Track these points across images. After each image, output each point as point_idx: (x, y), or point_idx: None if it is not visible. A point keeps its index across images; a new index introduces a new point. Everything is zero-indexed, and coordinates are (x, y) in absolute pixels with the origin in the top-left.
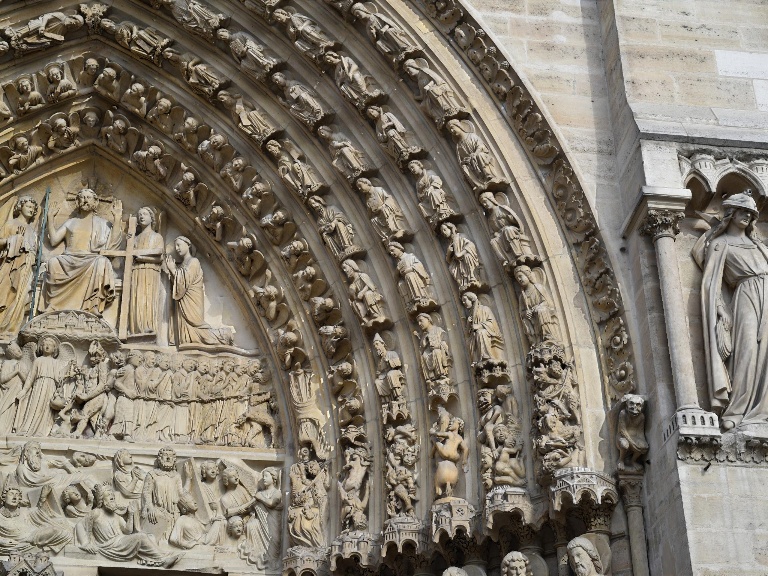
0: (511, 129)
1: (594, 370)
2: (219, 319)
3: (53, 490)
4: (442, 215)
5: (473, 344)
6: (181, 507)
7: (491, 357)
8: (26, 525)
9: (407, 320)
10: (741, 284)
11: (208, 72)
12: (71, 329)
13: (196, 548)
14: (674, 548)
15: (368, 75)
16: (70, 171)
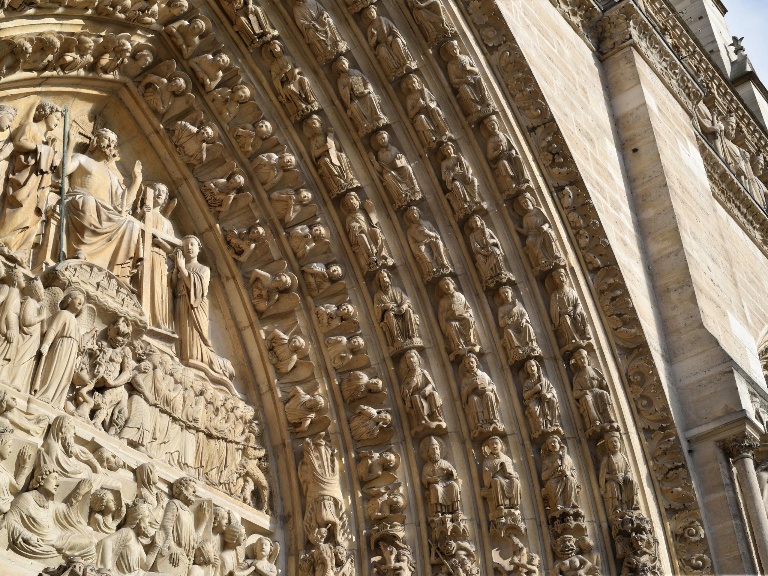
0: (593, 300)
1: (665, 551)
2: None
3: None
4: (535, 351)
5: (562, 488)
6: (198, 554)
7: None
8: (52, 523)
9: (464, 435)
10: None
11: None
12: (103, 292)
13: None
14: None
15: None
16: (87, 98)
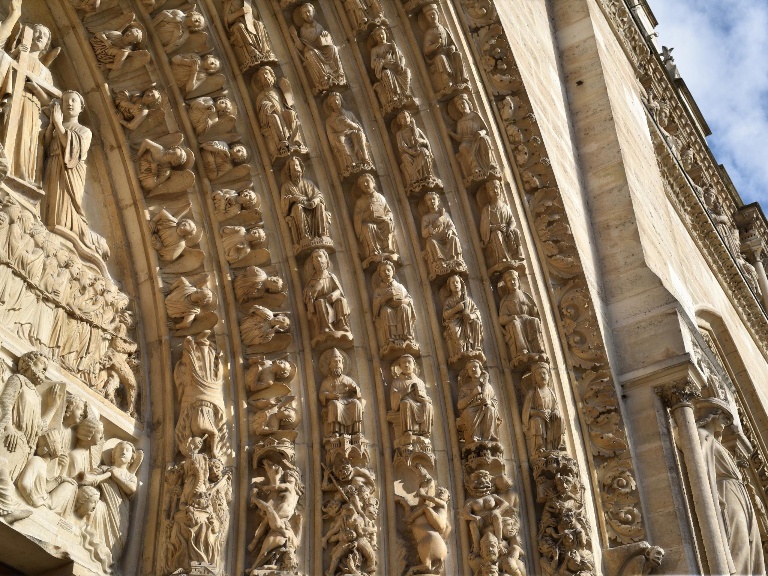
0: (528, 222)
1: (591, 501)
2: None
3: None
4: (460, 266)
5: (480, 417)
6: (42, 444)
7: None
8: None
9: (372, 351)
10: (725, 481)
11: None
12: None
13: (42, 509)
14: None
15: None
16: None
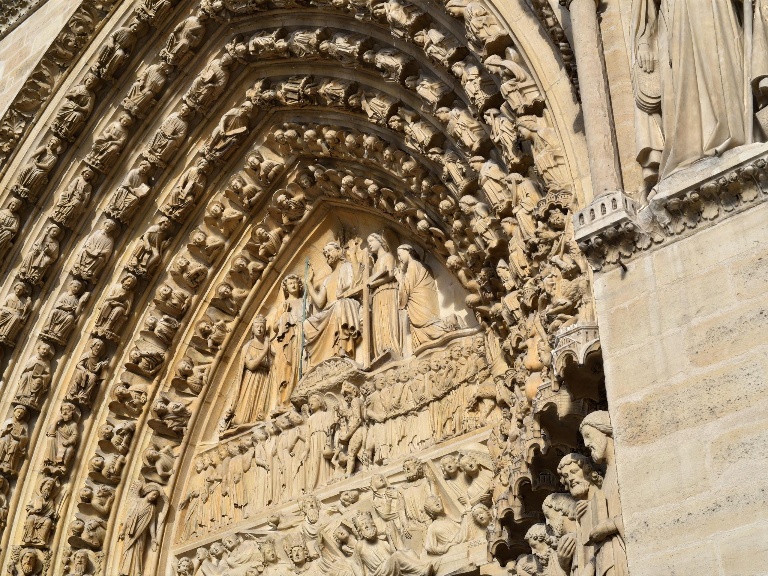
0: None
1: None
2: (452, 308)
3: (325, 536)
4: (478, 106)
5: (520, 231)
6: (429, 513)
7: (531, 236)
8: None
9: None
10: None
11: (336, 87)
12: (326, 379)
13: (451, 550)
14: None
15: (406, 5)
16: (320, 234)
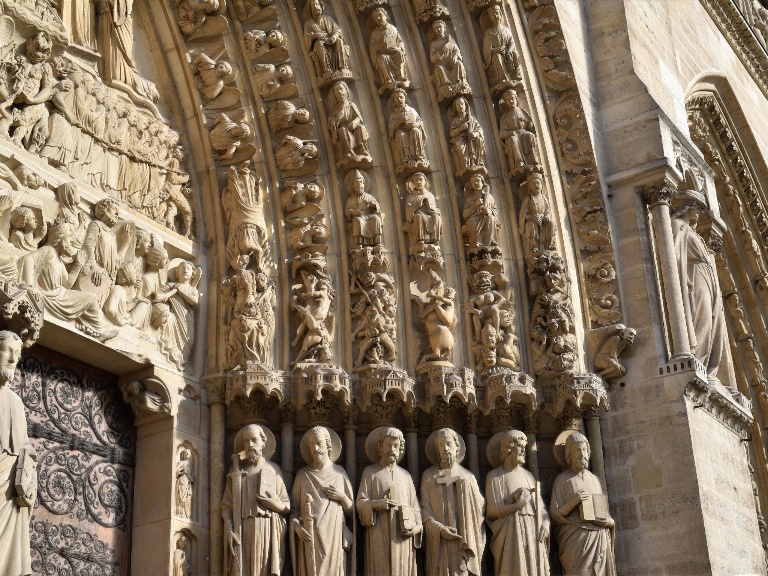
0: (527, 39)
1: (577, 290)
2: None
3: None
4: (465, 89)
5: (482, 226)
6: (120, 275)
7: None
8: None
9: (389, 170)
10: (696, 265)
11: None
12: (21, 4)
13: (126, 327)
14: (663, 463)
15: None
16: None
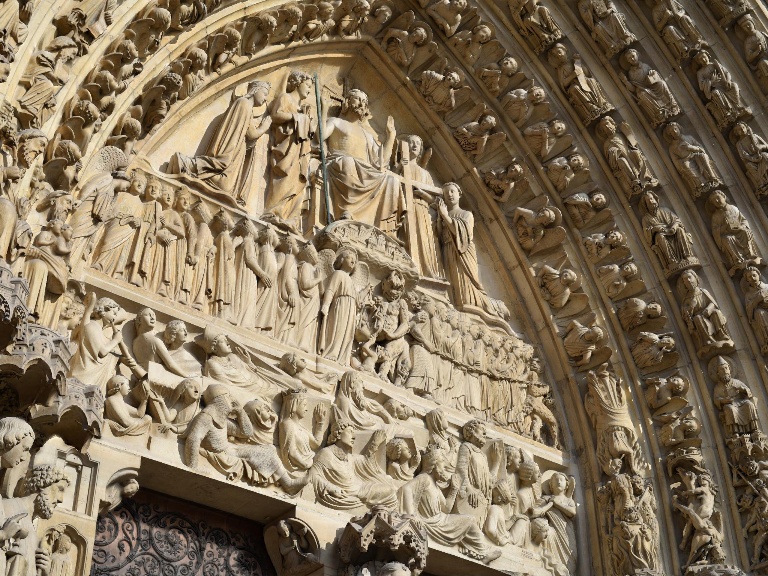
0: None
1: None
2: None
3: None
4: None
5: None
6: (496, 494)
7: None
8: (353, 475)
9: (754, 351)
10: None
11: None
12: (372, 248)
13: (507, 546)
14: None
15: None
16: (333, 62)
